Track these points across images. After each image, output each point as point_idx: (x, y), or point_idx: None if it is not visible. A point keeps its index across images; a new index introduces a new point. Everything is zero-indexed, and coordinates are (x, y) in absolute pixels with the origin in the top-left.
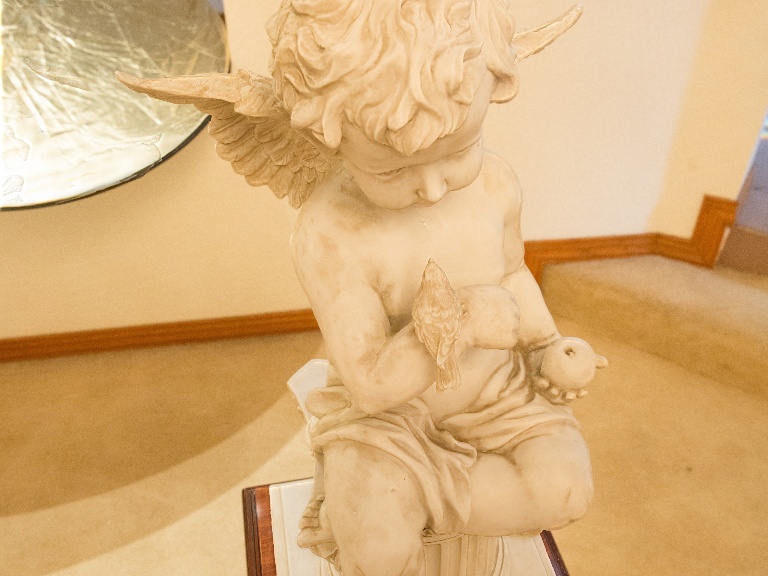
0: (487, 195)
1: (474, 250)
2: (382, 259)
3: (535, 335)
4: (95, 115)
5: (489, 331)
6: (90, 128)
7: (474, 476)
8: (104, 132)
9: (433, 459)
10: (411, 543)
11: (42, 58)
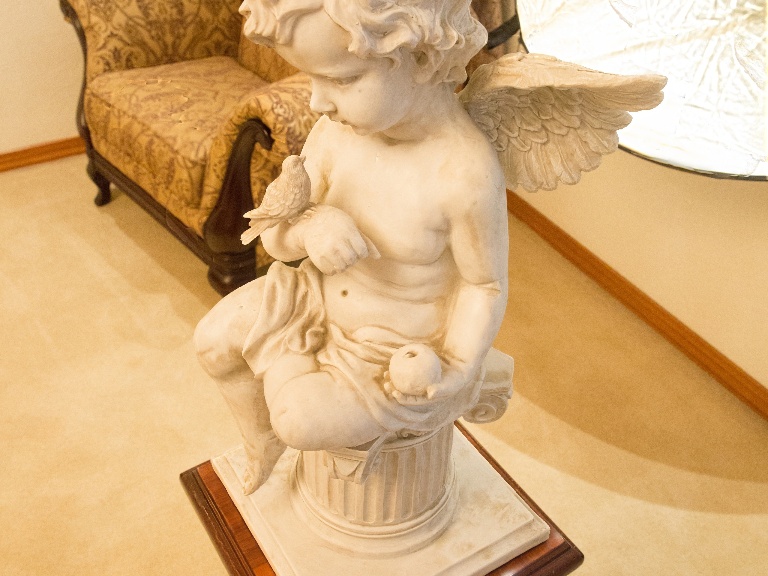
0: (437, 176)
1: (392, 205)
2: (337, 159)
3: (451, 347)
4: (742, 110)
5: (309, 241)
6: (724, 117)
7: (286, 356)
8: (730, 126)
9: (289, 327)
10: (218, 342)
11: (754, 44)
